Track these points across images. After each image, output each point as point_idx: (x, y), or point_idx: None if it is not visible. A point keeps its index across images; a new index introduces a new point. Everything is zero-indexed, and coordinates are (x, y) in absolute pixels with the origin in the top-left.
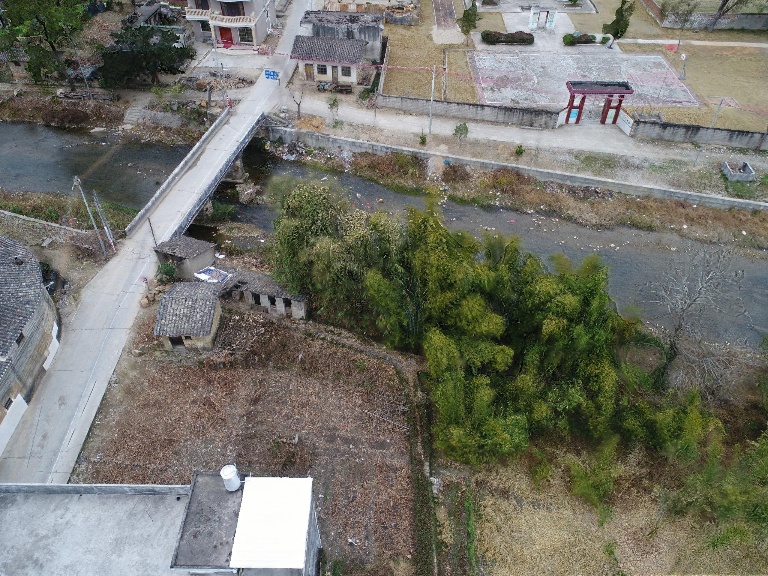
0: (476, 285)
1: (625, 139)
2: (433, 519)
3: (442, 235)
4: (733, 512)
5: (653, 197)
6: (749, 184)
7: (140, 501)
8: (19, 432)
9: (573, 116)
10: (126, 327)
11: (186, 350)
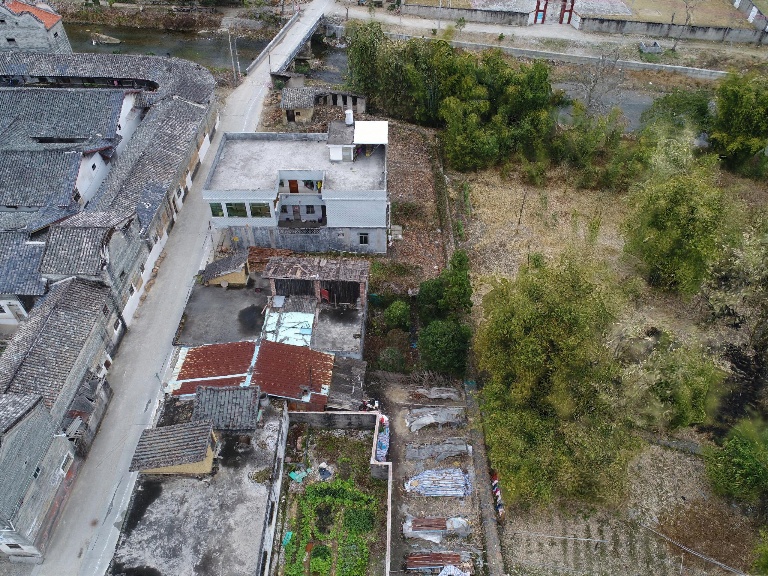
0: (469, 66)
1: (575, 32)
2: (445, 187)
3: (449, 47)
4: (610, 180)
5: (592, 64)
6: (657, 55)
7: (299, 143)
8: (209, 154)
9: (539, 18)
10: (257, 114)
11: (295, 125)
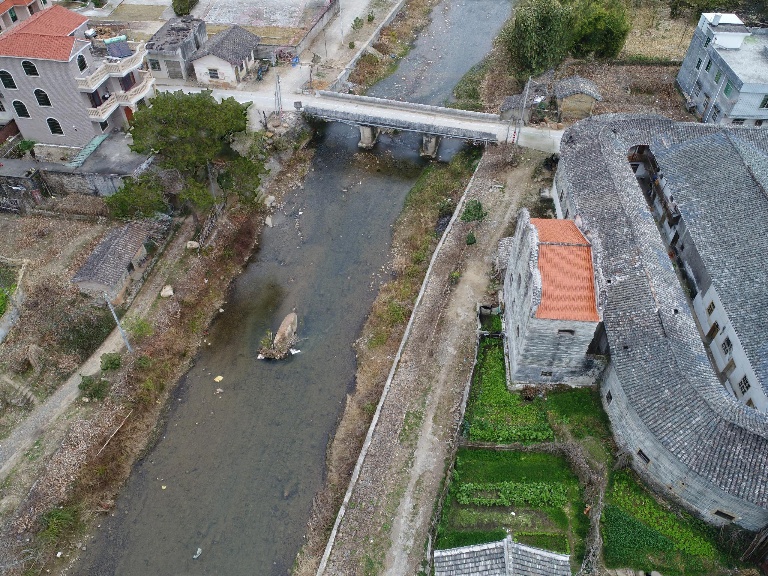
0: None
1: None
2: None
3: None
4: None
5: (407, 1)
6: None
7: None
8: None
9: None
10: None
11: None
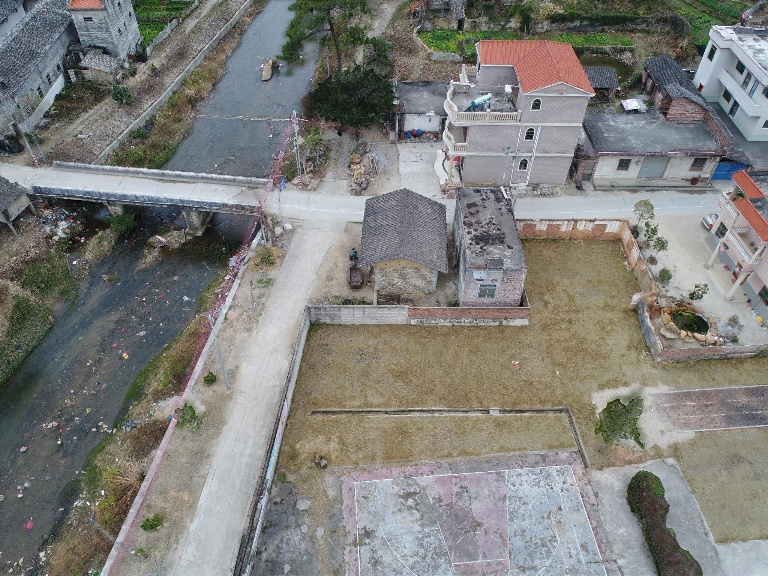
0: None
1: None
2: None
3: None
4: None
5: None
6: None
7: None
8: None
9: None
10: None
11: None
